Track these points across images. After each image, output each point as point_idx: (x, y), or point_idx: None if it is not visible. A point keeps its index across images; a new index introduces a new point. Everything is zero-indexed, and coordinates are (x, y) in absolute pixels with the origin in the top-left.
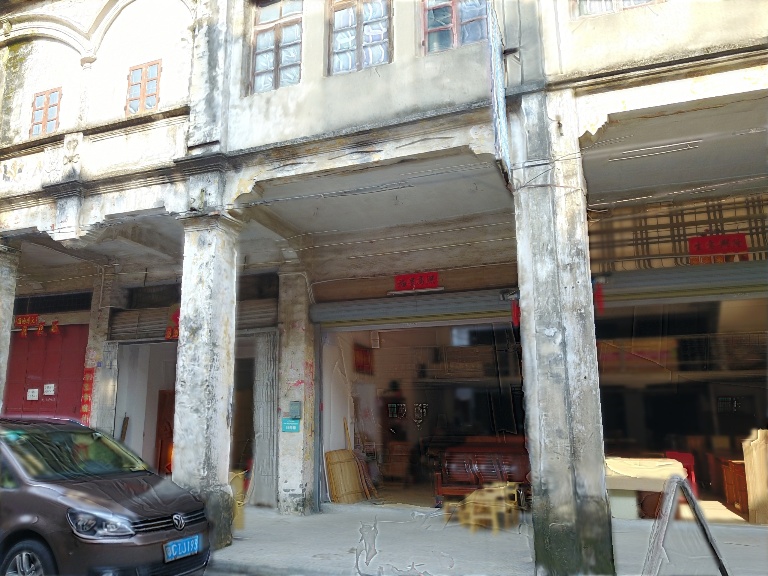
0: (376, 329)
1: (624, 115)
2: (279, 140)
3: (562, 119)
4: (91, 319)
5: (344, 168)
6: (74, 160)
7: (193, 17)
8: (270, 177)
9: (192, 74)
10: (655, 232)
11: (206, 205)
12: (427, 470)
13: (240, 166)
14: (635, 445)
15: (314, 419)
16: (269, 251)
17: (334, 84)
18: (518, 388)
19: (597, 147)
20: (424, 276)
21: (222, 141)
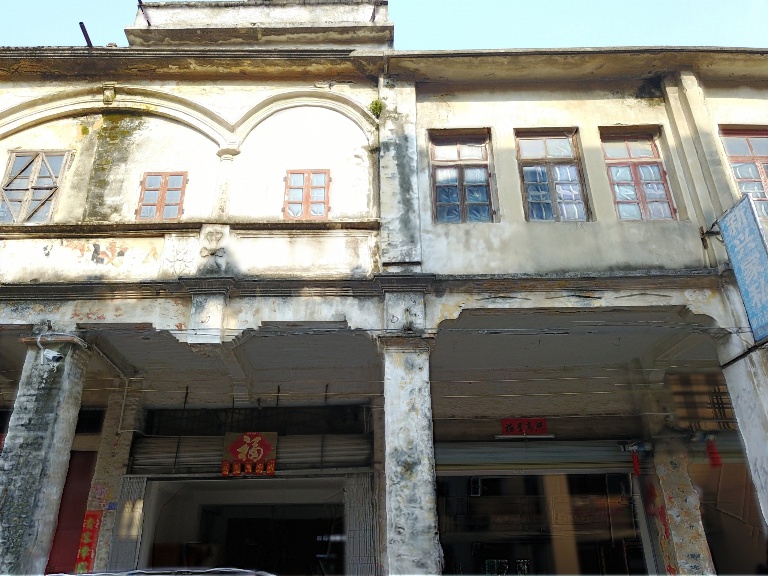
0: (479, 475)
1: None
2: (484, 272)
3: None
4: (102, 445)
5: (559, 309)
6: (218, 254)
7: (370, 138)
8: (481, 307)
9: (380, 192)
10: (727, 399)
11: (413, 326)
12: None
13: (443, 291)
14: None
15: None
16: (356, 381)
17: (539, 230)
18: (633, 542)
19: None
20: (532, 422)
21: (421, 263)
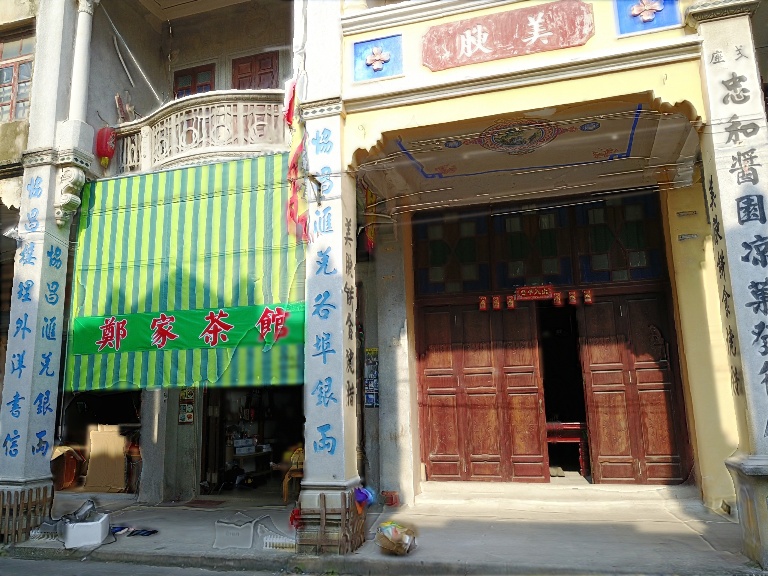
0: None
1: None
2: None
3: None
4: None
5: None
6: None
7: None
8: None
9: None
10: None
11: None
12: None
13: None
14: None
15: None
16: None
17: None
18: None
19: None
20: None
21: None
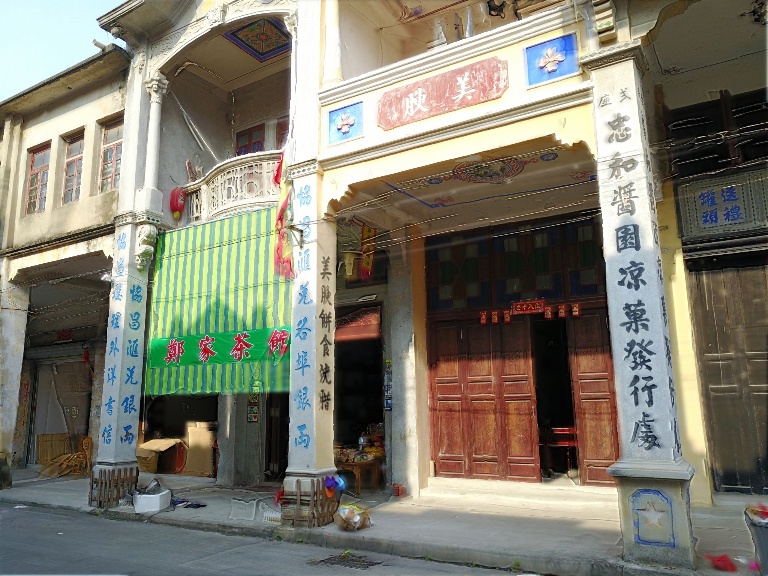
0: (53, 363)
1: (26, 269)
2: None
3: (1, 273)
4: None
5: None
6: None
7: None
8: None
9: None
10: None
11: None
12: (80, 445)
13: None
14: (166, 431)
15: (27, 415)
16: None
17: None
18: None
19: (54, 276)
20: (67, 333)
21: None
